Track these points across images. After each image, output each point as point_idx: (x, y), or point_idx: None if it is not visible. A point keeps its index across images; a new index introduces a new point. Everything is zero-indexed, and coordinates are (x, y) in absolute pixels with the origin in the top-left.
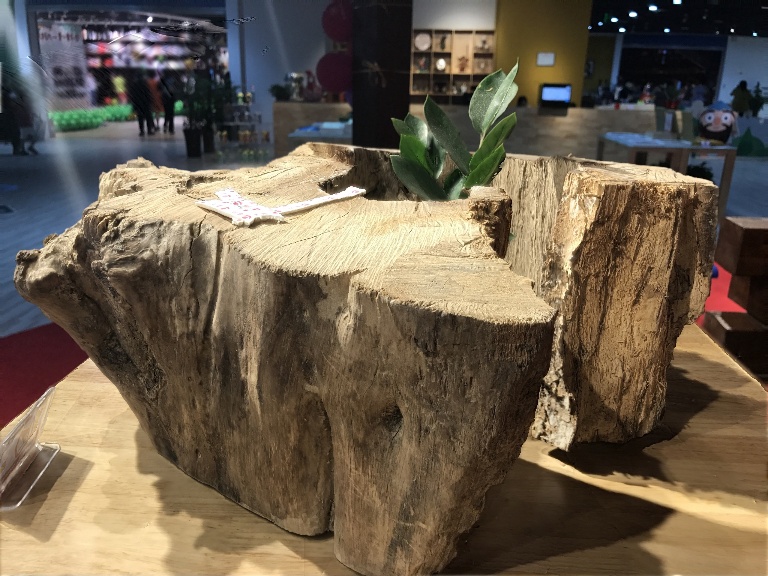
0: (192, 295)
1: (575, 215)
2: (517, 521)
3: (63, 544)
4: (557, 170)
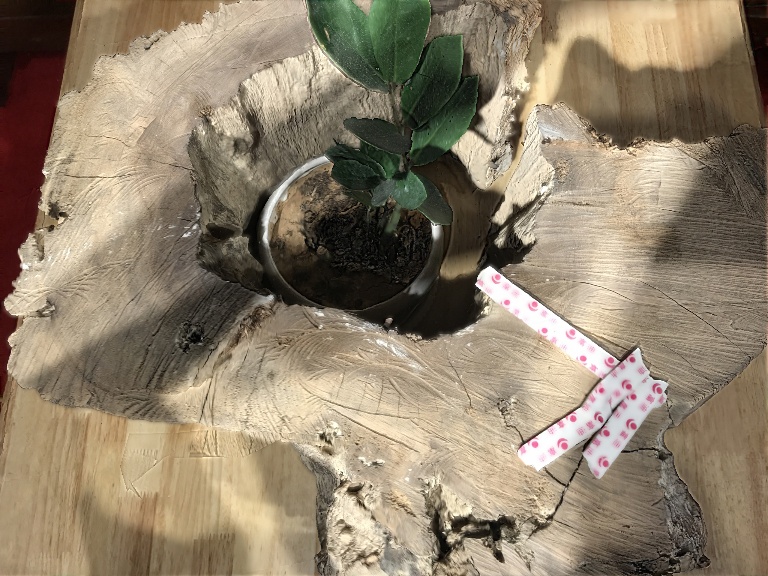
0: None
1: None
2: None
3: None
4: None
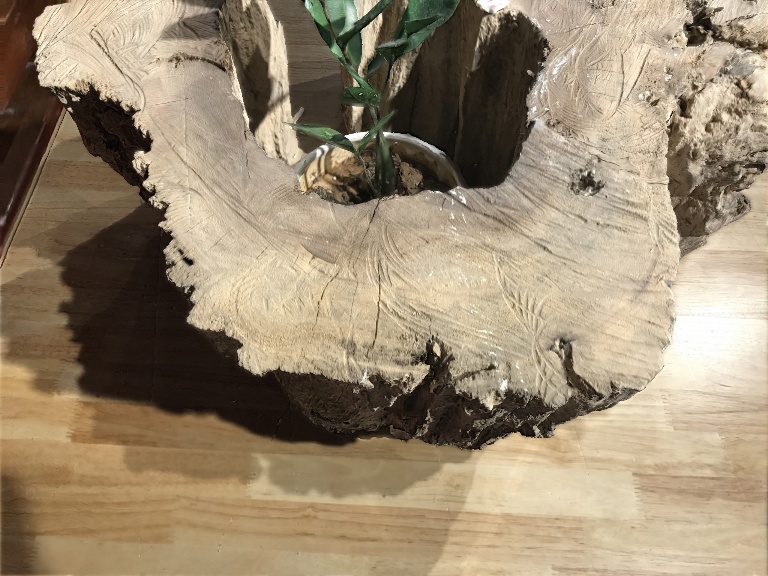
0: None
1: None
2: (335, 101)
3: None
4: None
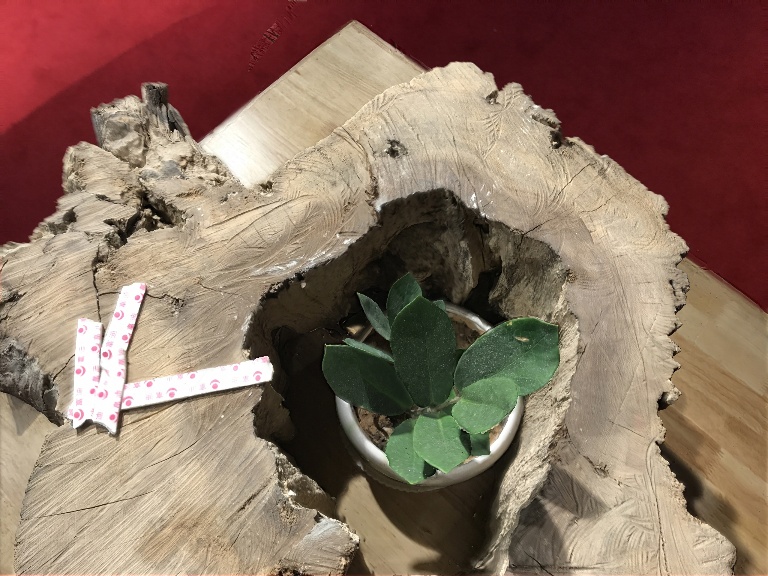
0: (53, 421)
1: None
2: None
3: (27, 445)
4: (535, 494)
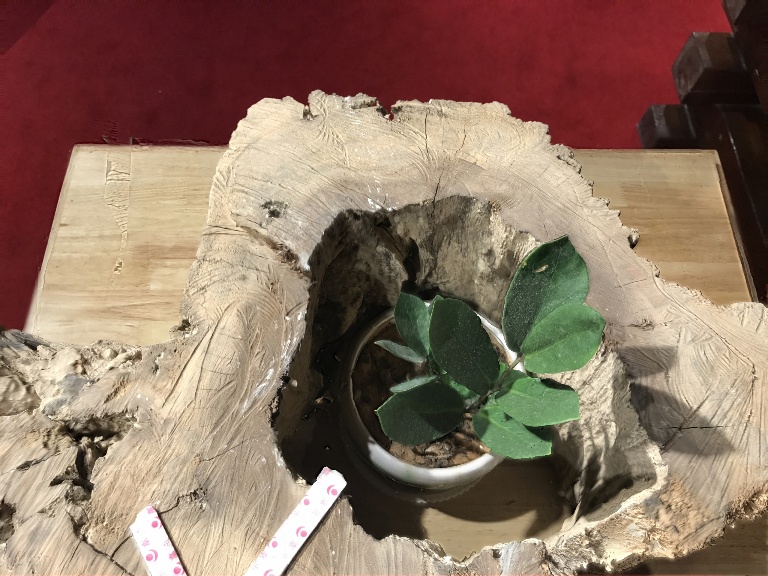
0: None
1: (634, 535)
2: None
3: None
4: (622, 383)
